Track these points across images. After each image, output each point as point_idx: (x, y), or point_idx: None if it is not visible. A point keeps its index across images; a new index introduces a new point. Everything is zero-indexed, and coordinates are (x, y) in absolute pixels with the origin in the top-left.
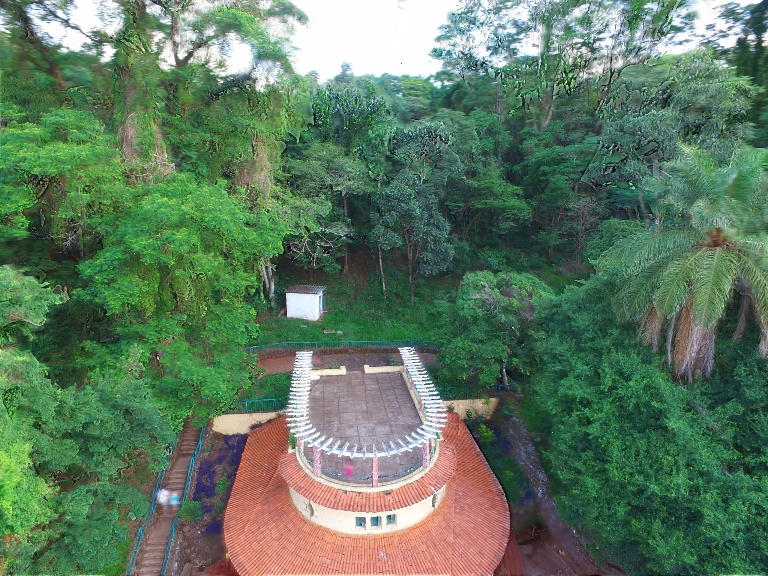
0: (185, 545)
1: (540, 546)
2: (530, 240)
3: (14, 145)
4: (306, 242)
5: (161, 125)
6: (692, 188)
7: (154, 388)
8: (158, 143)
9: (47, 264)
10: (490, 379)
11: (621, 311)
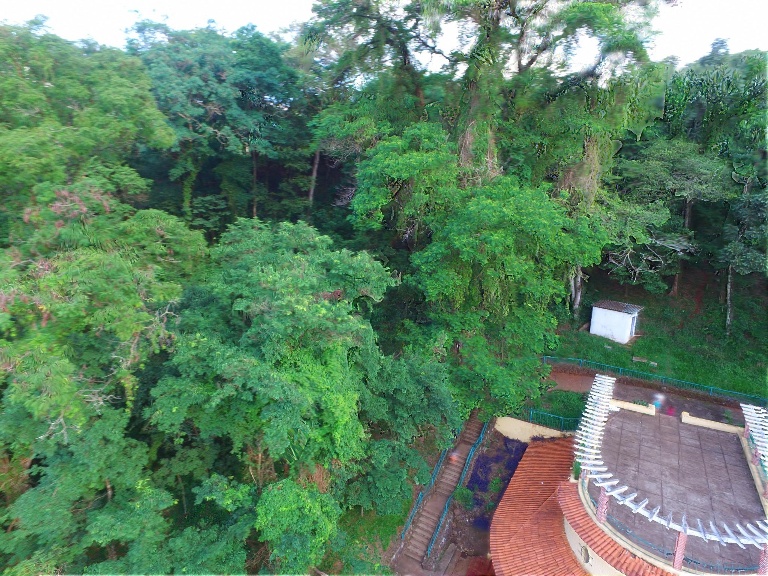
0: (453, 526)
1: None
2: None
3: (384, 154)
4: (629, 254)
5: (494, 131)
6: None
7: (451, 374)
8: (491, 148)
9: (389, 251)
10: None
11: None
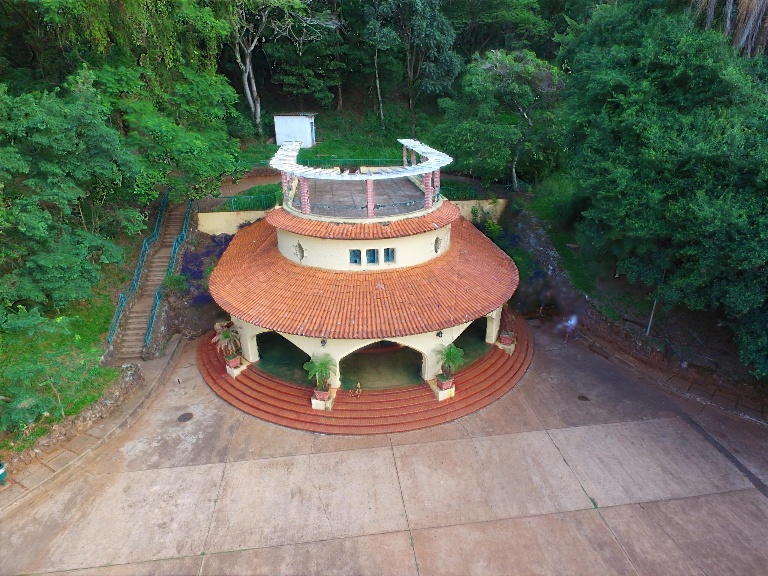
0: (172, 315)
1: (548, 320)
2: None
3: None
4: (290, 26)
5: None
6: None
7: (120, 144)
8: None
9: None
10: (499, 162)
11: None
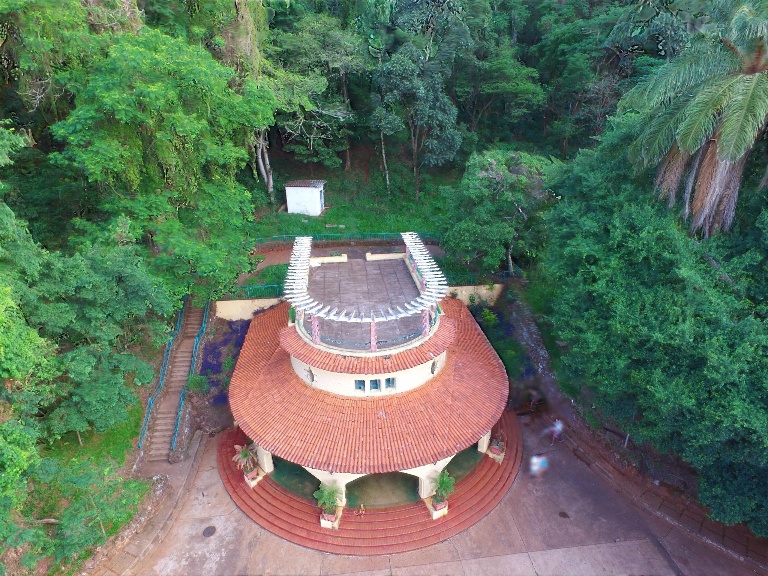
0: (194, 414)
1: (537, 416)
2: (544, 134)
3: None
4: (302, 123)
5: None
6: (736, 1)
7: (149, 265)
8: None
9: (33, 152)
10: (494, 261)
11: (638, 160)
